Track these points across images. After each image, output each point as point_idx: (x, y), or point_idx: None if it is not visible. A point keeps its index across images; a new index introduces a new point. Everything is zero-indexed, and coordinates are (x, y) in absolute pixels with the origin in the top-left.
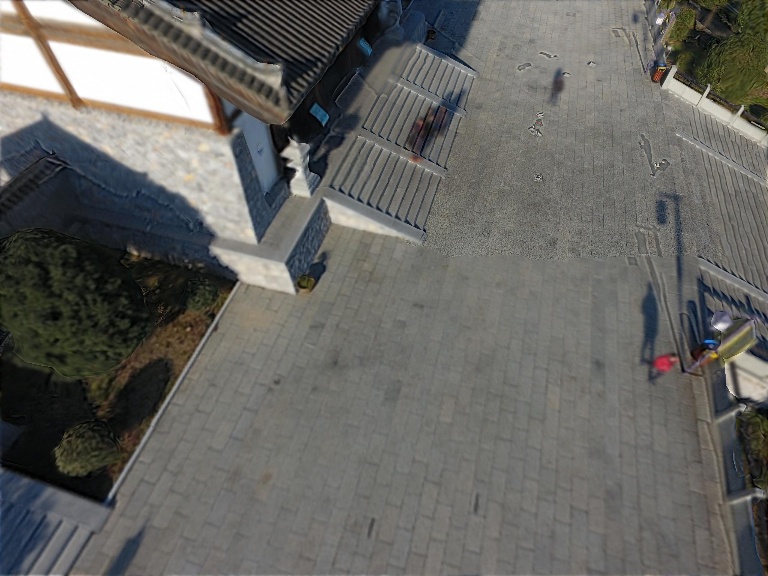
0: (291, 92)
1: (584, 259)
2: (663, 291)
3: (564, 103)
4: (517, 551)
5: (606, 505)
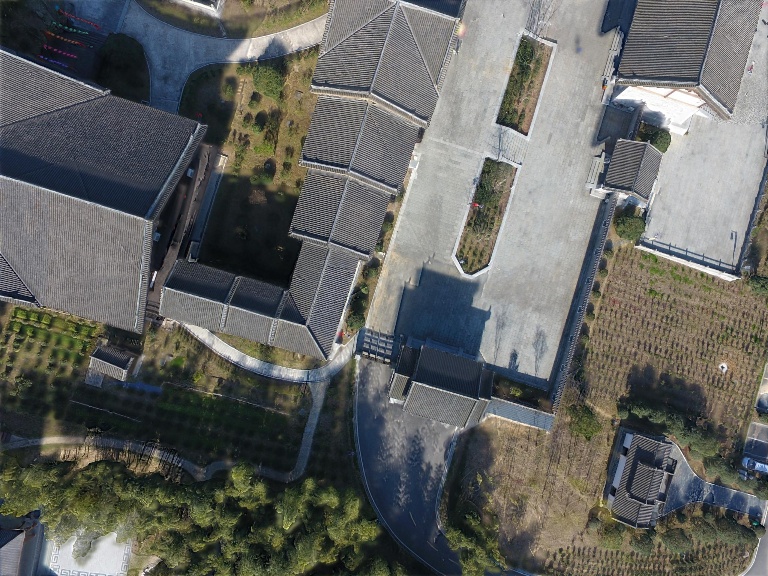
0: None
1: (752, 126)
2: (767, 136)
3: (763, 55)
4: (724, 189)
5: (741, 182)
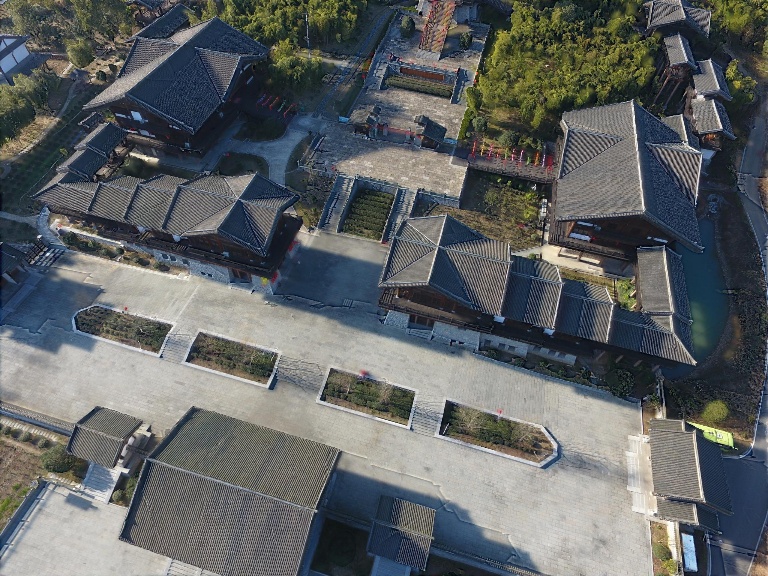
0: (123, 538)
1: None
2: None
3: None
4: None
5: None
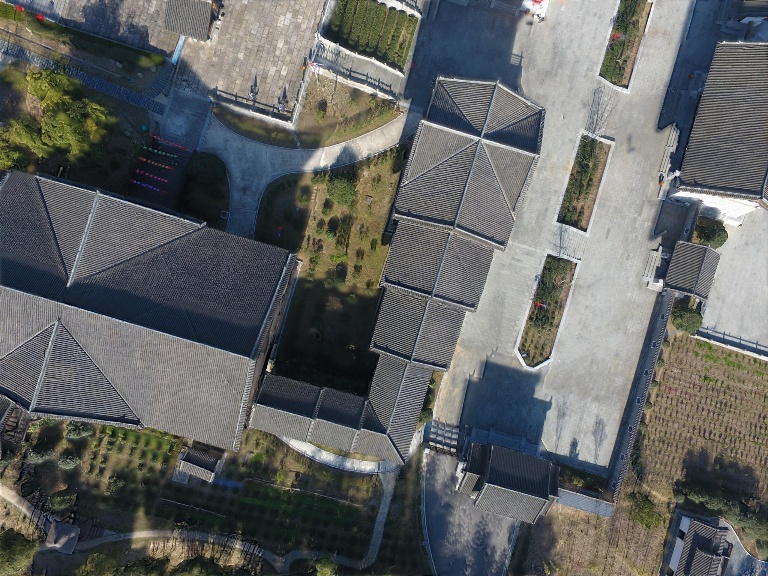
0: None
1: None
2: None
3: None
4: None
5: None
